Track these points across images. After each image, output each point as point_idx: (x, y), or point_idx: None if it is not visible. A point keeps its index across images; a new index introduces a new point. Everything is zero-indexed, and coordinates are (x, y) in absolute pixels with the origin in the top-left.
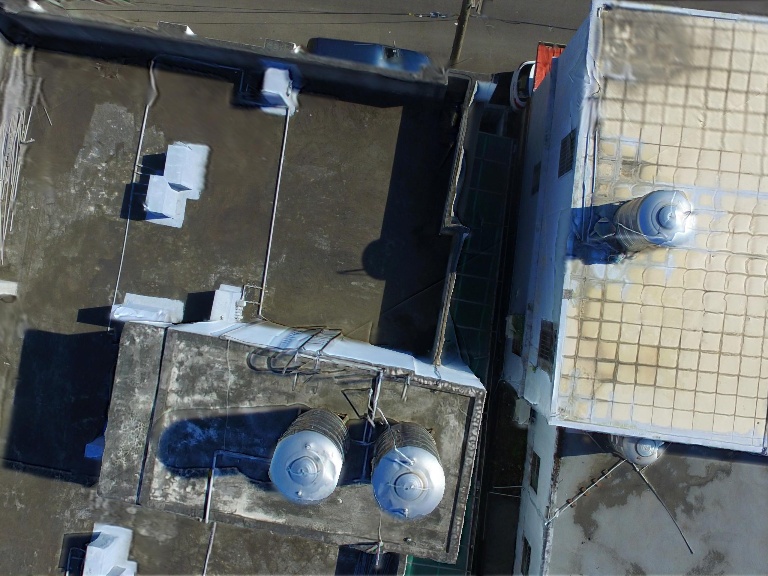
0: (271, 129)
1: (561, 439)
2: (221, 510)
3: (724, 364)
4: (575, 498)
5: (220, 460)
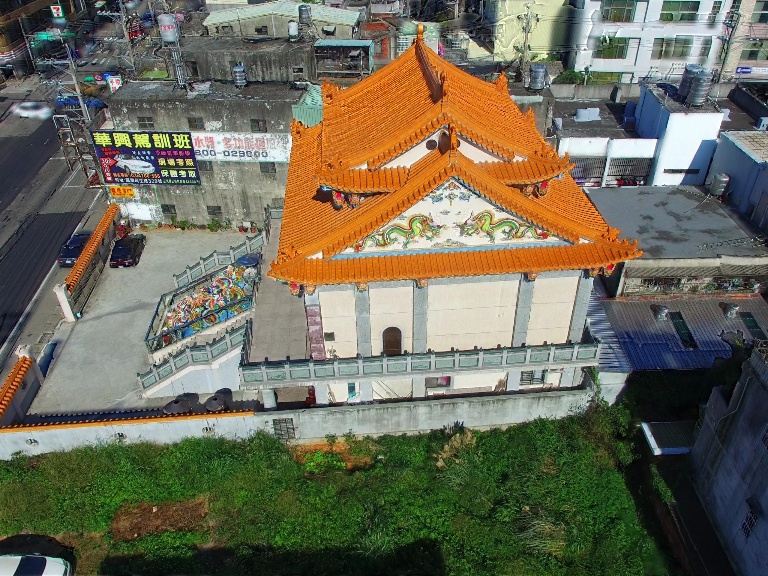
0: None
1: None
2: (652, 90)
3: None
4: None
5: (665, 89)
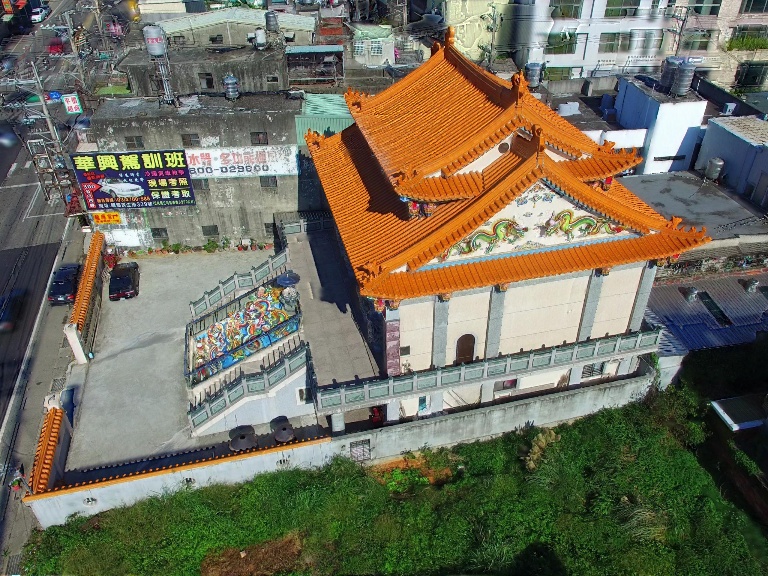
0: (716, 113)
1: (693, 170)
2: None
3: (764, 135)
4: (678, 175)
5: (644, 81)
